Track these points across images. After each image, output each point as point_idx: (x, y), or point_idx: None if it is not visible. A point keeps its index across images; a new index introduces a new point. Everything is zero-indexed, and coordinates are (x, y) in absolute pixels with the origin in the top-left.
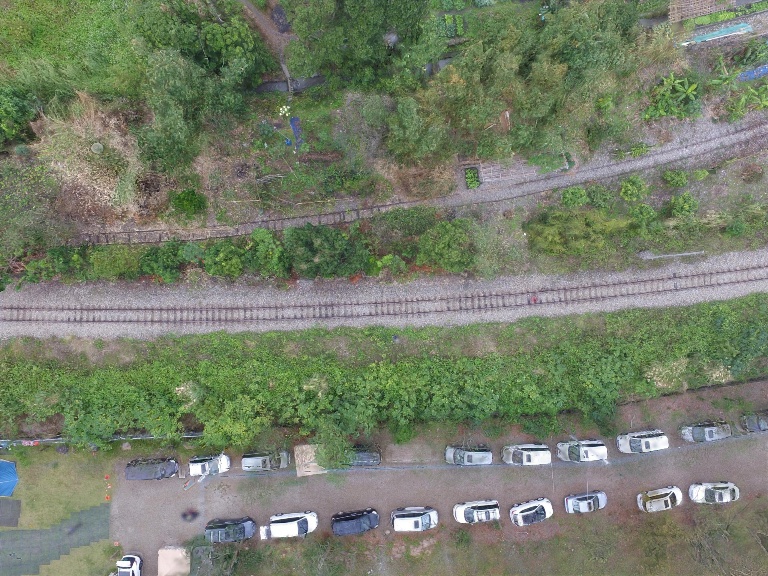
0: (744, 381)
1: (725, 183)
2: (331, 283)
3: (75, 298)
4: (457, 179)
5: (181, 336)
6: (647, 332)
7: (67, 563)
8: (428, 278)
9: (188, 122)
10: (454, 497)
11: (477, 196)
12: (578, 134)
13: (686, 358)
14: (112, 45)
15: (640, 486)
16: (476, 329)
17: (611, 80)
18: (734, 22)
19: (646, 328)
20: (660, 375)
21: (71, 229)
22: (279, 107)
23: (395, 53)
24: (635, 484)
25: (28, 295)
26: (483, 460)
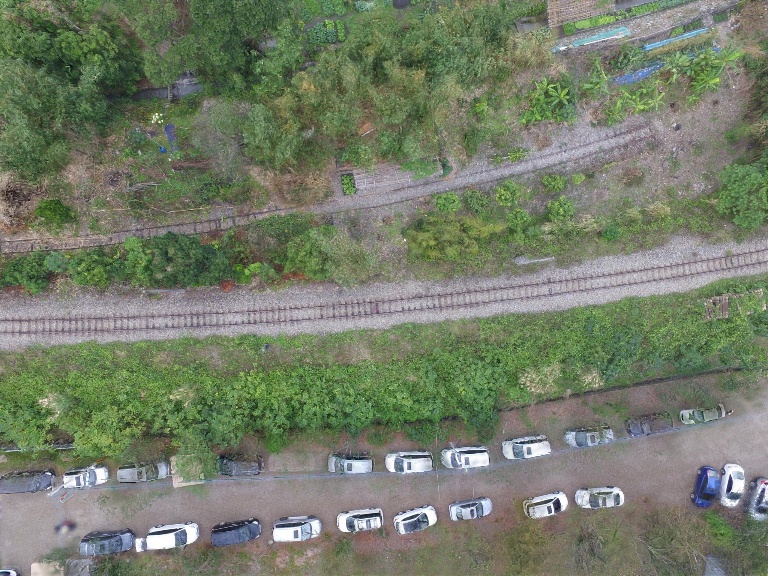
0: (629, 385)
1: (606, 187)
2: (204, 292)
3: None
4: (334, 185)
5: (50, 347)
6: (521, 338)
7: None
8: (302, 285)
9: (44, 131)
10: (338, 506)
11: (355, 202)
12: (456, 139)
13: (559, 363)
14: None
15: (527, 492)
16: (350, 336)
17: (488, 85)
18: (615, 26)
19: (519, 334)
20: (534, 381)
21: None
22: (153, 114)
23: None
24: (522, 490)
25: None
26: (363, 468)
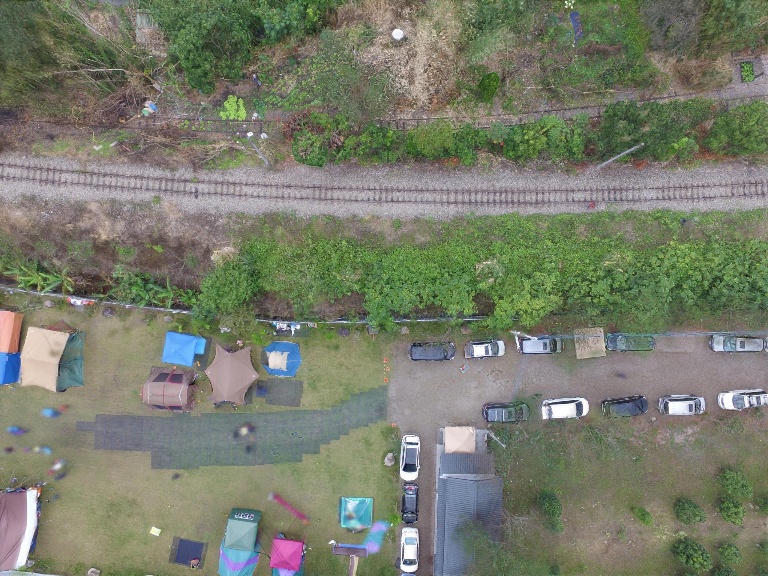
0: None
1: None
2: (617, 169)
3: (374, 179)
4: None
5: (475, 217)
6: None
7: (346, 443)
8: (711, 165)
9: None
10: (717, 386)
11: (750, 90)
12: None
13: None
14: None
15: None
16: (759, 215)
17: None
18: None
19: None
20: None
21: (364, 115)
22: (559, 2)
23: None
24: None
25: (329, 175)
26: (755, 346)
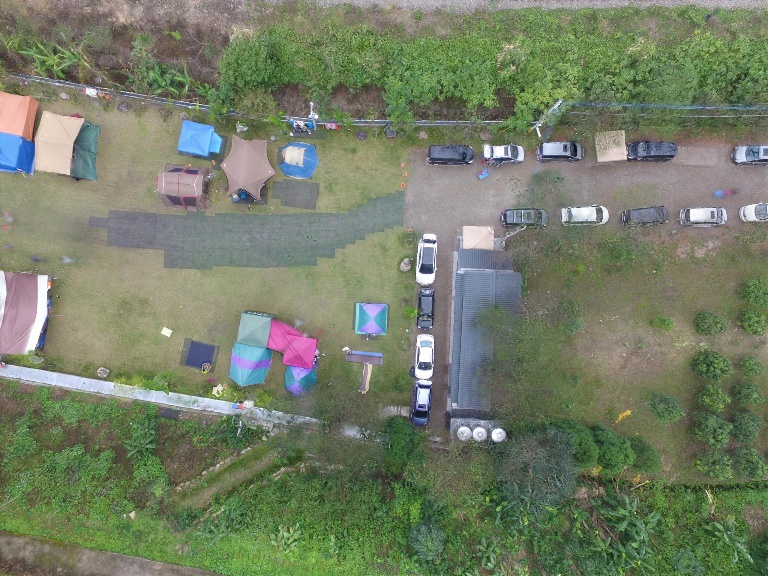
0: None
1: None
2: None
3: None
4: None
5: (496, 11)
6: None
7: (362, 248)
8: None
9: None
10: (739, 201)
11: None
12: None
13: None
14: None
15: None
16: None
17: None
18: None
19: None
20: None
21: None
22: None
23: None
24: None
25: None
26: None
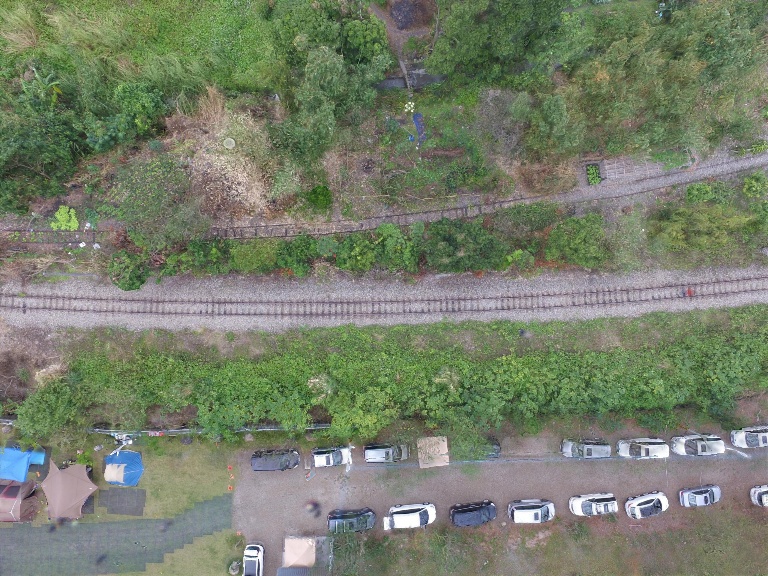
0: None
1: None
2: (457, 278)
3: (207, 291)
4: (578, 175)
5: (310, 329)
6: None
7: (190, 552)
8: (553, 273)
9: None
10: (569, 490)
11: (598, 192)
12: (698, 131)
13: None
14: (234, 42)
15: (753, 480)
16: (600, 324)
17: (732, 77)
18: None
19: None
20: None
21: (200, 223)
22: (402, 103)
23: (527, 50)
24: (748, 478)
25: (161, 288)
26: (602, 453)
